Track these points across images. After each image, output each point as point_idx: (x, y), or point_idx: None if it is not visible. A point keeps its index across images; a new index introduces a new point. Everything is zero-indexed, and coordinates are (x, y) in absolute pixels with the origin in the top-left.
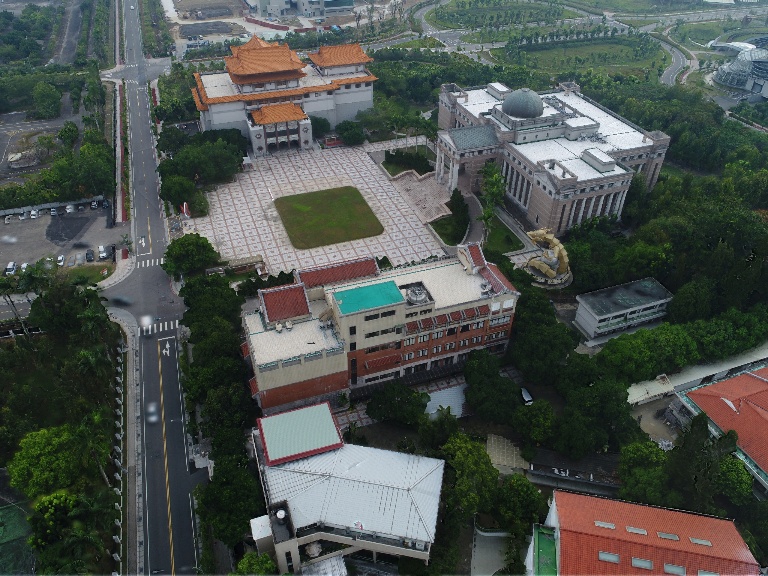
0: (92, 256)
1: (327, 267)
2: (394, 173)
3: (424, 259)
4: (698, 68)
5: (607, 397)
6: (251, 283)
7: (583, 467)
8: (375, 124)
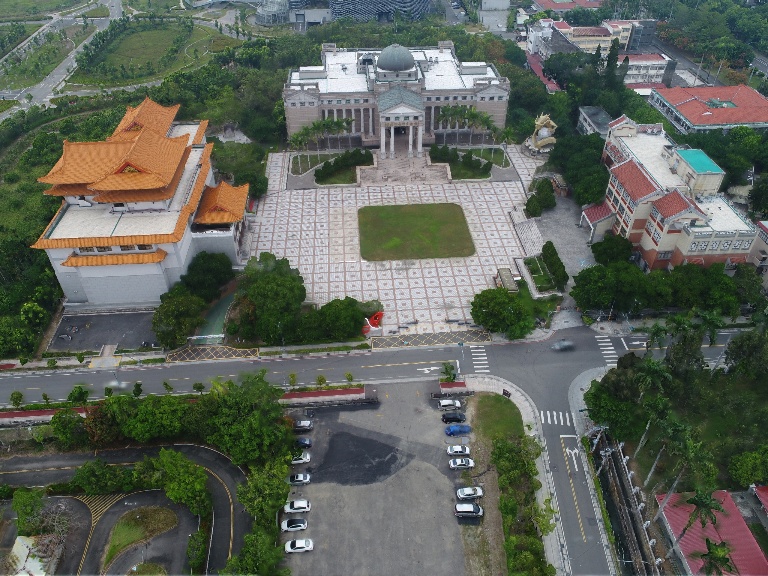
0: (459, 413)
1: (648, 178)
2: (348, 180)
3: (574, 165)
4: (234, 23)
5: (718, 138)
6: (564, 270)
7: (746, 170)
8: (248, 165)
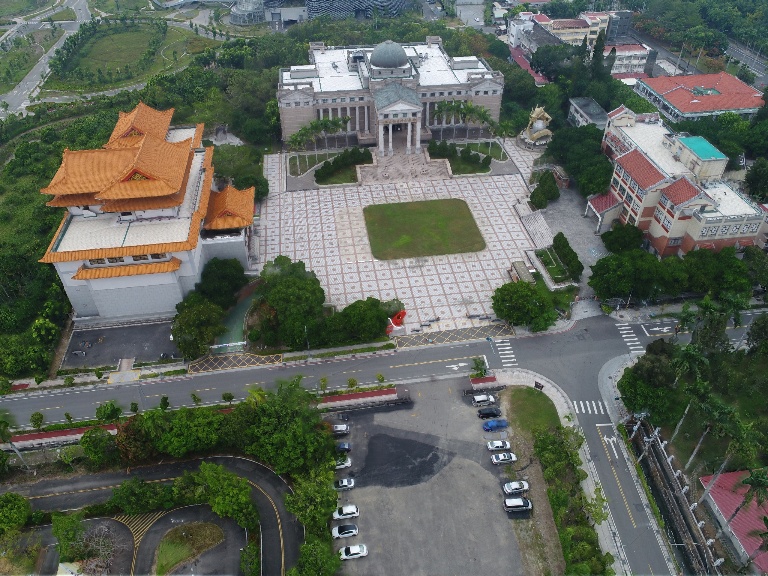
0: (494, 408)
1: (655, 166)
2: (349, 180)
3: (576, 156)
4: (208, 24)
5: (709, 124)
6: None
7: None
8: (246, 168)
